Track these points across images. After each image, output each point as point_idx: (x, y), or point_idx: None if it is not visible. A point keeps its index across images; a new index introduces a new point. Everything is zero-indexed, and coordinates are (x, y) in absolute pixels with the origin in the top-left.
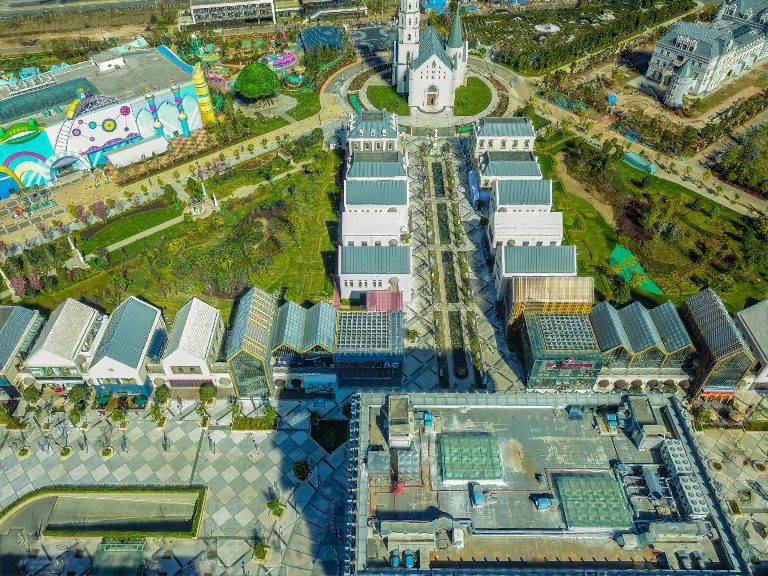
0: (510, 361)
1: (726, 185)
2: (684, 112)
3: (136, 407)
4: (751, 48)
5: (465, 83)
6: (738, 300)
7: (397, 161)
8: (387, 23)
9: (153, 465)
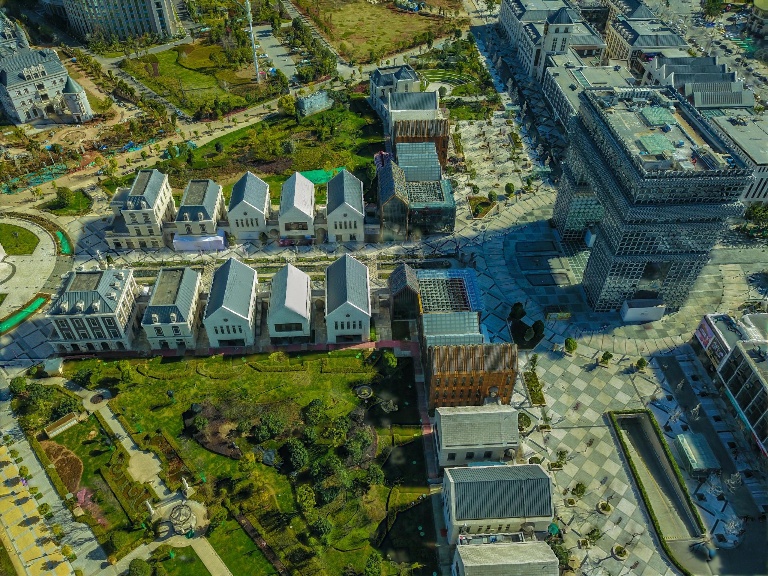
0: (428, 240)
1: (223, 119)
2: (107, 115)
3: None
4: None
5: None
6: None
7: (184, 269)
8: None
9: (601, 461)
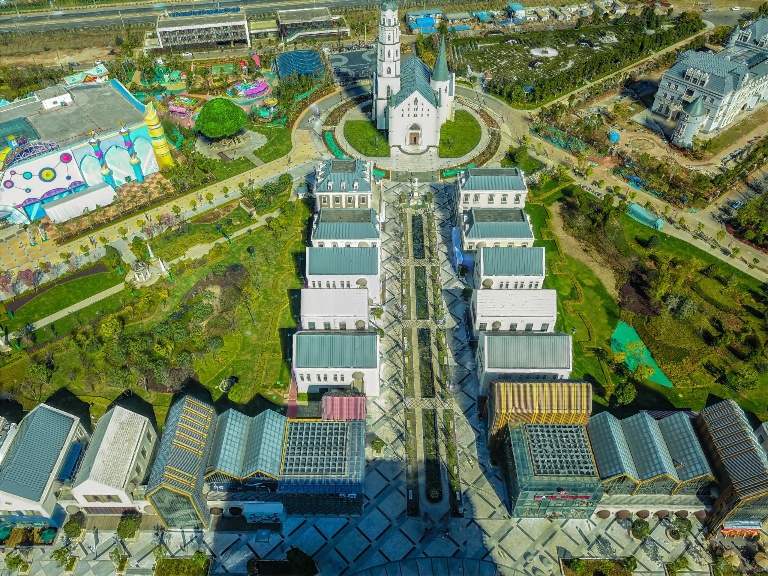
0: (492, 478)
1: (743, 244)
2: (694, 154)
3: (42, 542)
4: (767, 80)
5: (452, 118)
6: (761, 395)
7: (369, 221)
8: (371, 46)
9: None
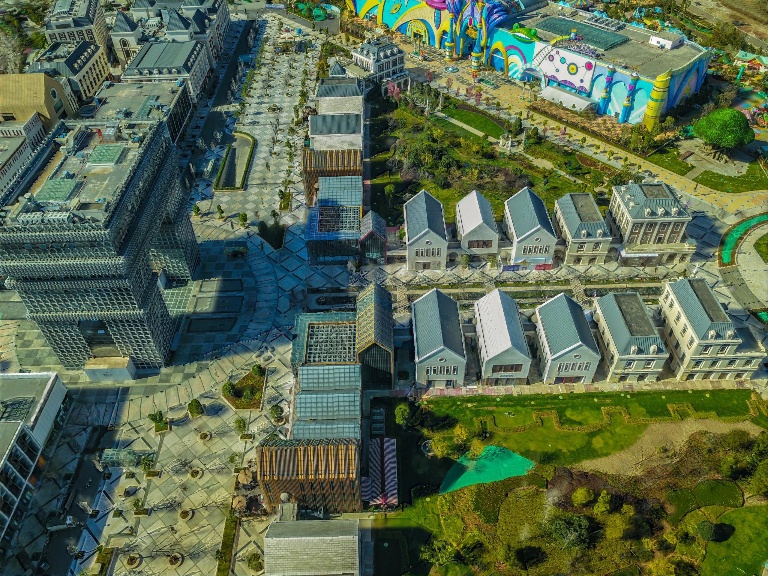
0: None
1: None
2: None
3: None
4: None
5: None
6: None
7: None
8: None
9: (263, 170)
